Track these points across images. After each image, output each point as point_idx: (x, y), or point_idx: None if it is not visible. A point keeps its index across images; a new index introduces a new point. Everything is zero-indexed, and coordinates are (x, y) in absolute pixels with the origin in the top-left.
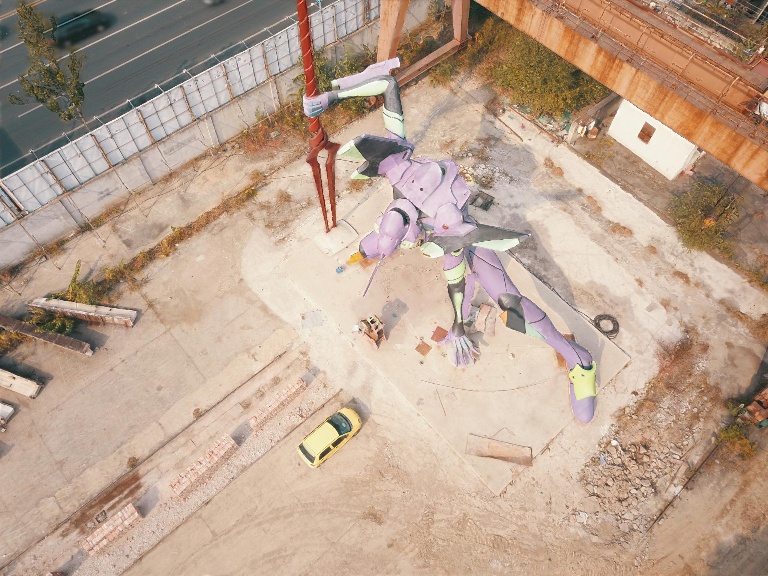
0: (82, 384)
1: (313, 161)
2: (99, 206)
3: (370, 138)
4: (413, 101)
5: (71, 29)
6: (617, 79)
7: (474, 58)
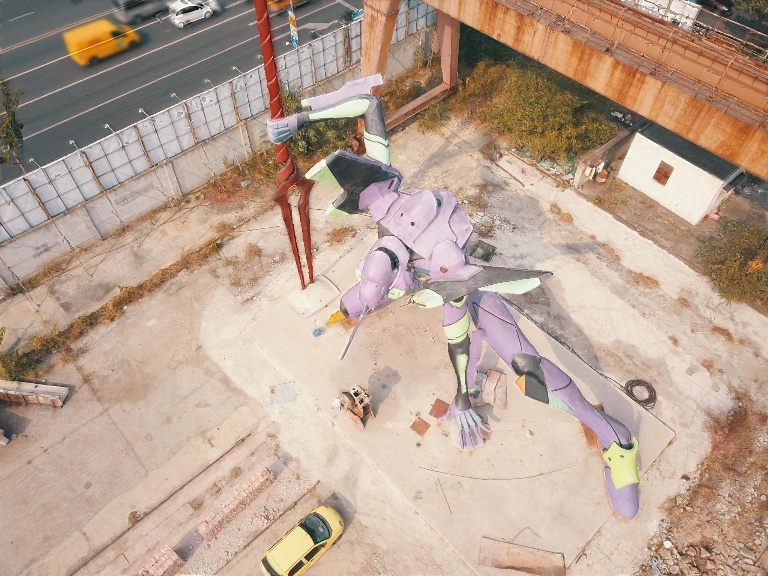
0: None
1: (282, 200)
2: (35, 264)
3: (346, 157)
4: (400, 147)
5: (27, 80)
6: (639, 97)
7: (466, 101)
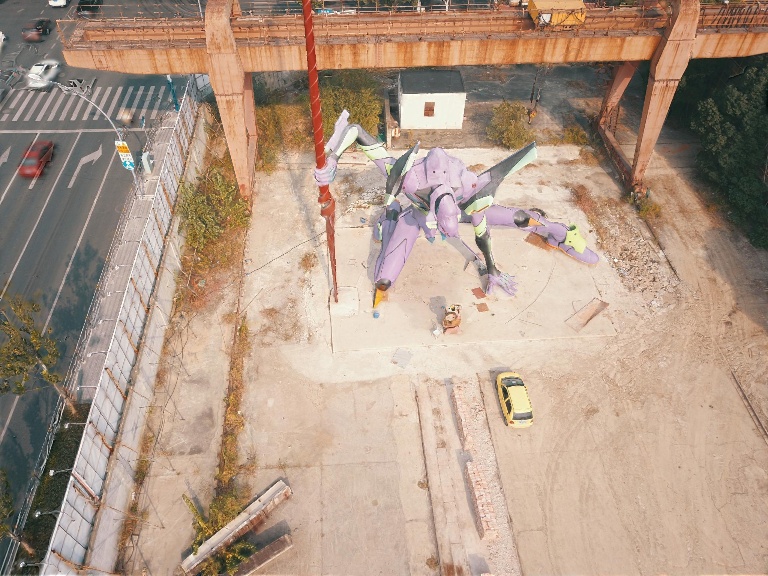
0: (316, 570)
1: None
2: (135, 447)
3: None
4: (268, 192)
5: None
6: (450, 56)
7: (277, 139)
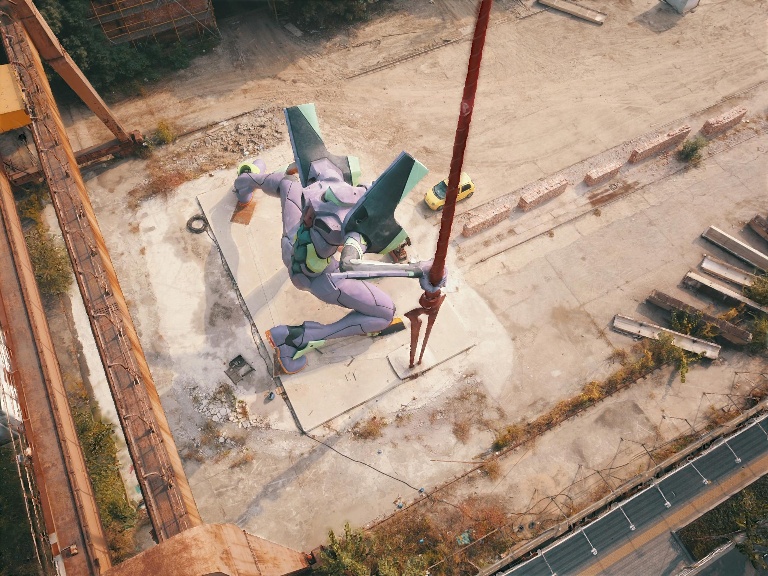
0: (650, 276)
1: None
2: None
3: (397, 163)
4: None
5: None
6: None
7: None
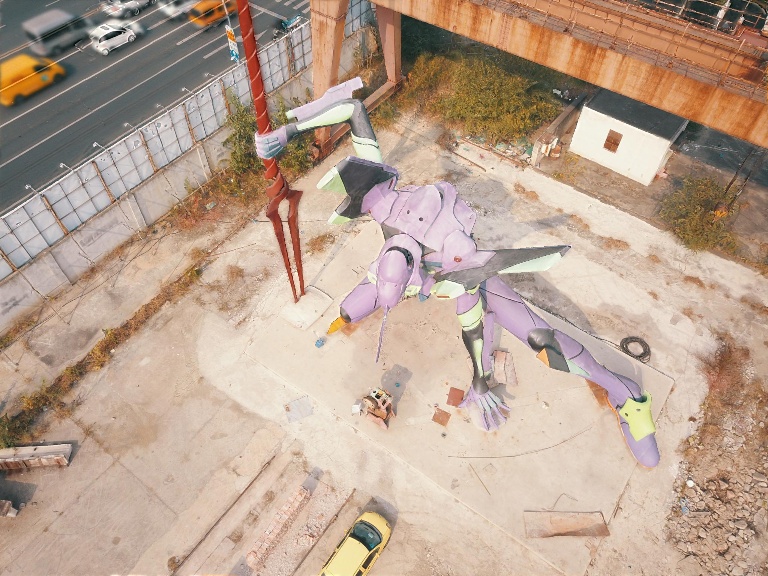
0: (6, 559)
1: (274, 215)
2: (5, 321)
3: (355, 162)
4: None
5: None
6: (601, 71)
7: (414, 96)
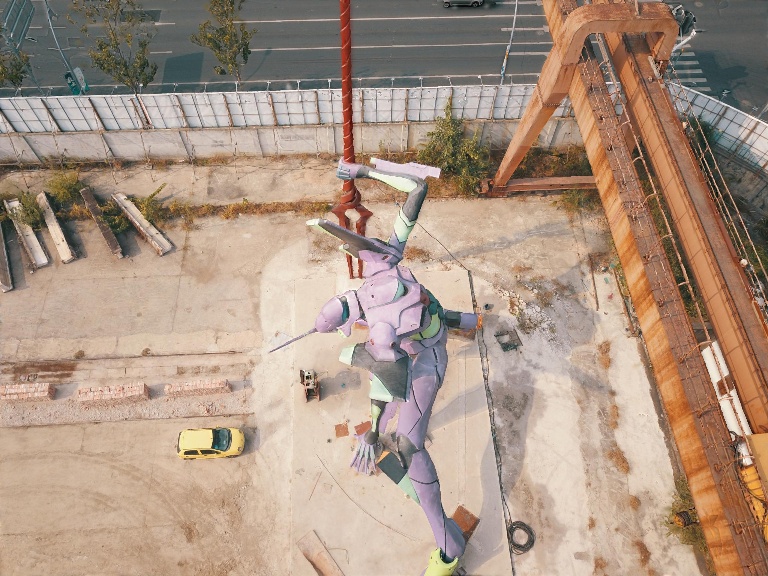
0: (98, 275)
1: (339, 214)
2: (211, 151)
3: (336, 226)
4: (527, 210)
5: (308, 1)
6: (645, 313)
7: None
